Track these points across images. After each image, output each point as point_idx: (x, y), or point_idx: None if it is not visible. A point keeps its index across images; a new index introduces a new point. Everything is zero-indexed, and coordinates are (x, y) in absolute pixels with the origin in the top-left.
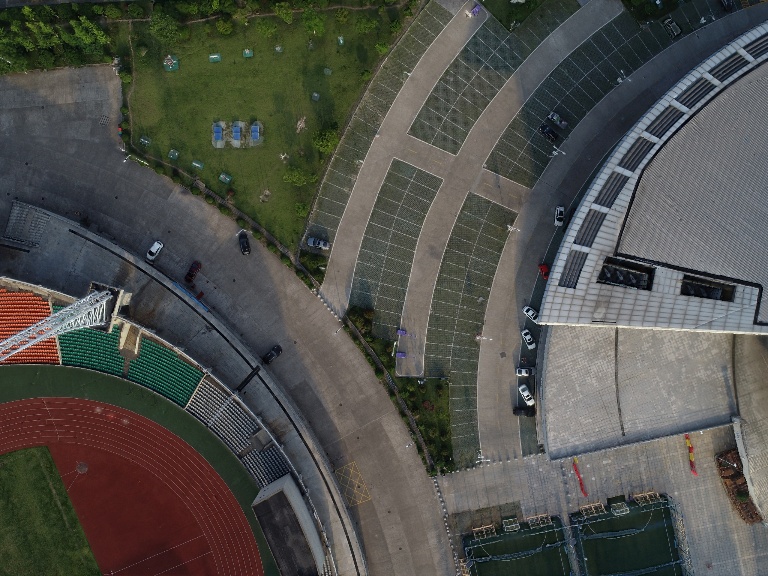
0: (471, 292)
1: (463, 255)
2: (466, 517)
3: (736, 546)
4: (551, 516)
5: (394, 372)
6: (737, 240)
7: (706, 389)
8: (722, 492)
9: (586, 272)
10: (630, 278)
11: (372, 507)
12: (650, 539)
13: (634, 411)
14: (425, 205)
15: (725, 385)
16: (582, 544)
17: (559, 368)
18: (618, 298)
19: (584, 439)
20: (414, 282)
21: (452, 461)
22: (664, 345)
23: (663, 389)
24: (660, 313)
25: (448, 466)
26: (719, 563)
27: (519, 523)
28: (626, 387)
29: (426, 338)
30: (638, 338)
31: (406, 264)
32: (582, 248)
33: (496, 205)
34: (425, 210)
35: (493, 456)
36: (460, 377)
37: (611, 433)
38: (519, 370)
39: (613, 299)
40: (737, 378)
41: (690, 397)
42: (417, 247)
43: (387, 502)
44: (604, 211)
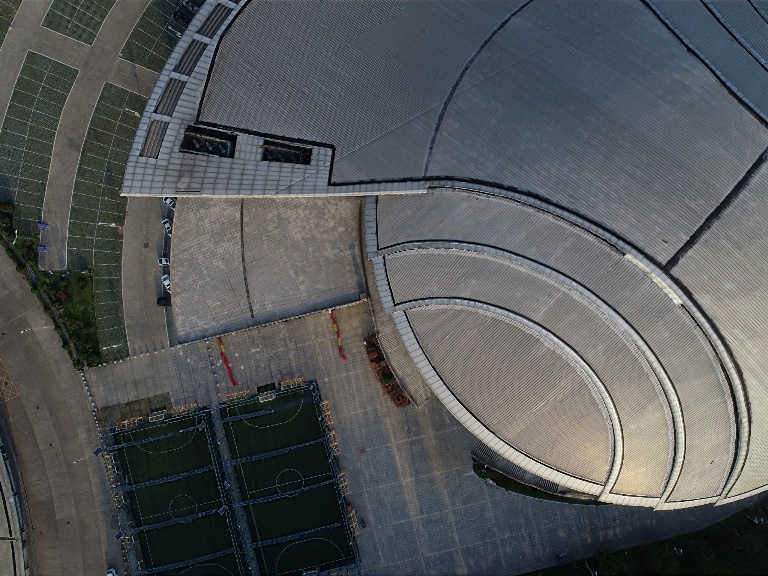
0: (112, 183)
1: (102, 146)
2: (116, 410)
3: (389, 431)
4: (201, 406)
5: (37, 266)
6: (312, 102)
7: (334, 268)
8: (372, 376)
9: (168, 141)
10: (219, 148)
11: (20, 404)
12: (302, 426)
13: (262, 292)
14: (62, 97)
15: (353, 263)
16: (233, 434)
17: (185, 251)
18: (201, 167)
19: (213, 322)
20: (54, 175)
21: (96, 353)
22: (290, 225)
23: (290, 269)
24: (243, 180)
25: (89, 358)
26: (372, 448)
27: (169, 415)
28: (253, 268)
29: (68, 231)
30: (263, 218)
31: (45, 157)
32: (162, 117)
33: (133, 94)
34: (62, 102)
35: (140, 348)
36: (104, 269)
37: (240, 315)
38: (160, 259)
39: (196, 168)
40: (365, 256)
41: (318, 276)
42: (56, 139)
43: (35, 398)
44: (184, 79)
